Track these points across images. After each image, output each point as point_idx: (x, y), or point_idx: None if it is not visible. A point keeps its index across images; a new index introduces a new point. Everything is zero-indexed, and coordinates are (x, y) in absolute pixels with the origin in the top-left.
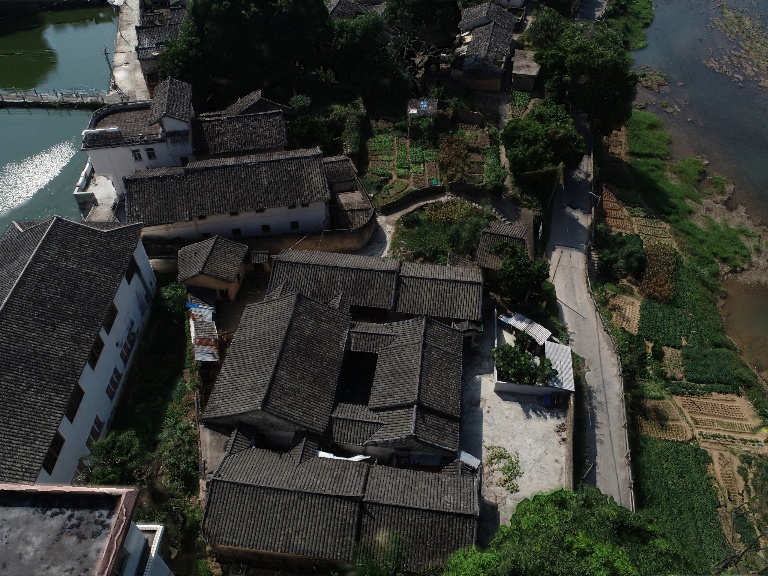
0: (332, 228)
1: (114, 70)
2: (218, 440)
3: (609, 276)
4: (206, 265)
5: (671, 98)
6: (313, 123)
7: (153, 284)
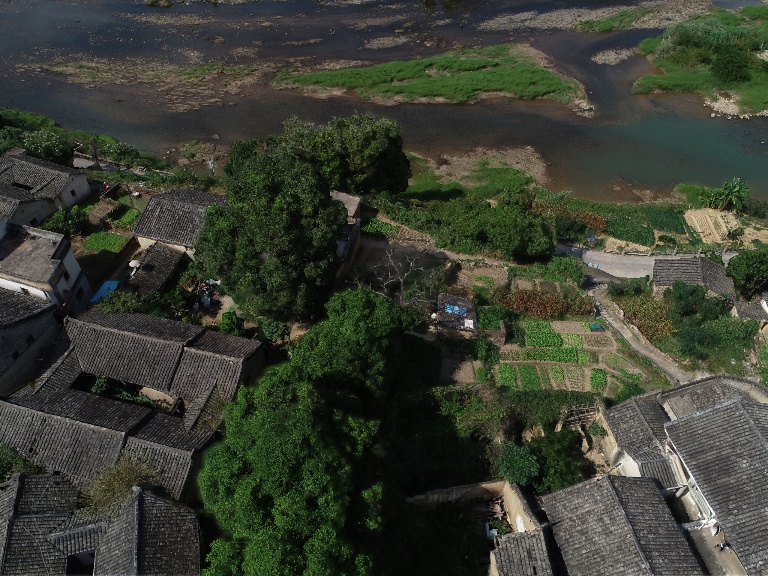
0: None
1: None
2: None
3: None
4: None
5: None
6: None
7: None
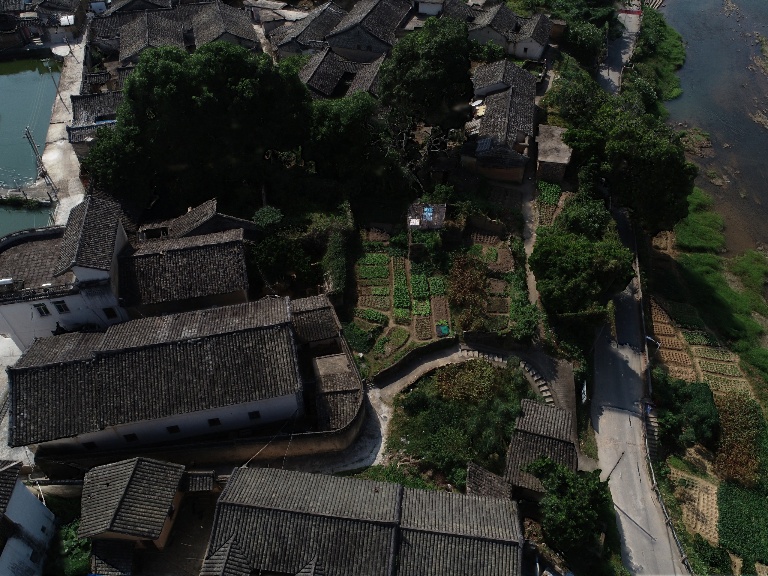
0: (307, 414)
1: (46, 149)
2: None
3: (672, 446)
4: (118, 514)
5: (717, 165)
6: (284, 246)
7: (48, 526)
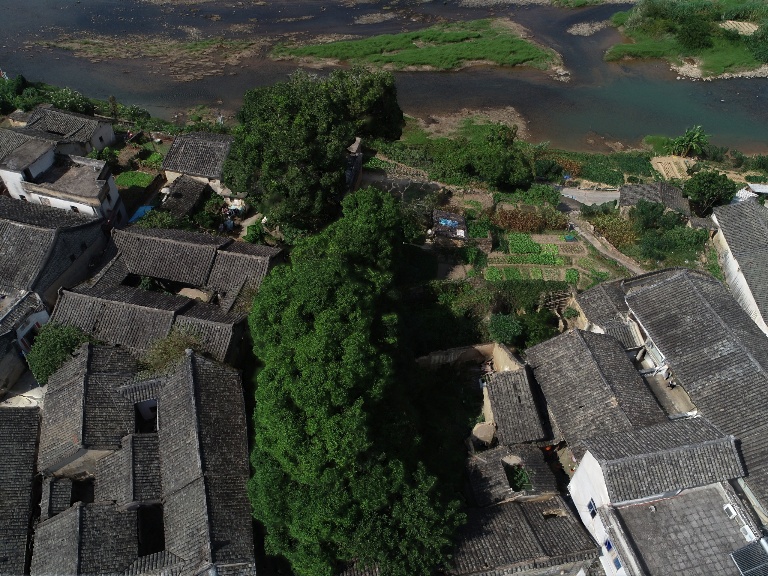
0: None
1: None
2: None
3: None
4: None
5: None
6: None
7: None
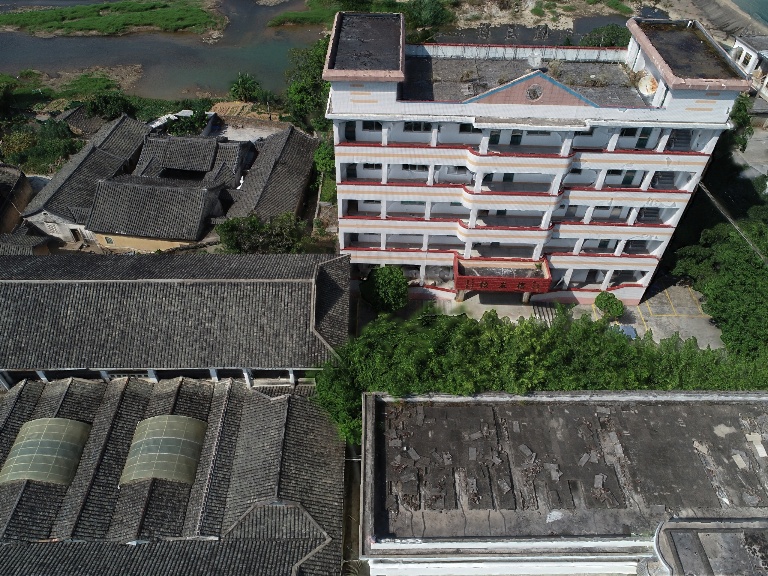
0: None
1: None
2: (214, 233)
3: None
4: None
5: None
6: None
7: None
